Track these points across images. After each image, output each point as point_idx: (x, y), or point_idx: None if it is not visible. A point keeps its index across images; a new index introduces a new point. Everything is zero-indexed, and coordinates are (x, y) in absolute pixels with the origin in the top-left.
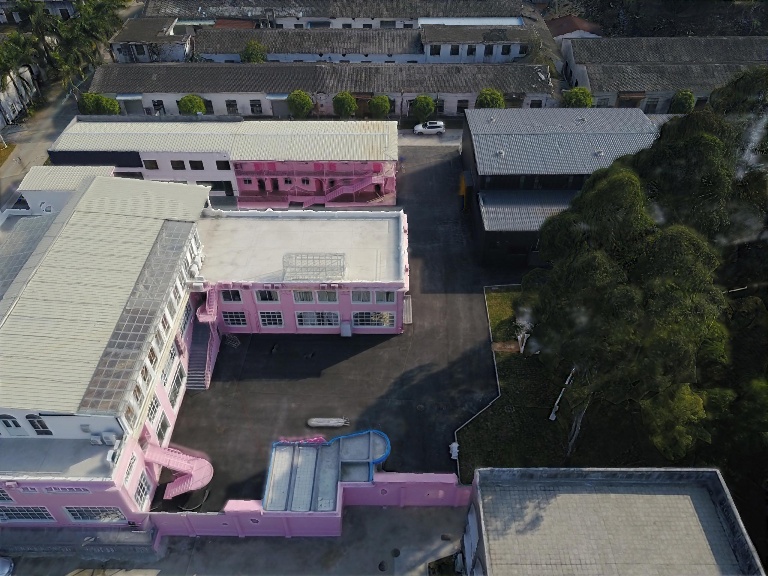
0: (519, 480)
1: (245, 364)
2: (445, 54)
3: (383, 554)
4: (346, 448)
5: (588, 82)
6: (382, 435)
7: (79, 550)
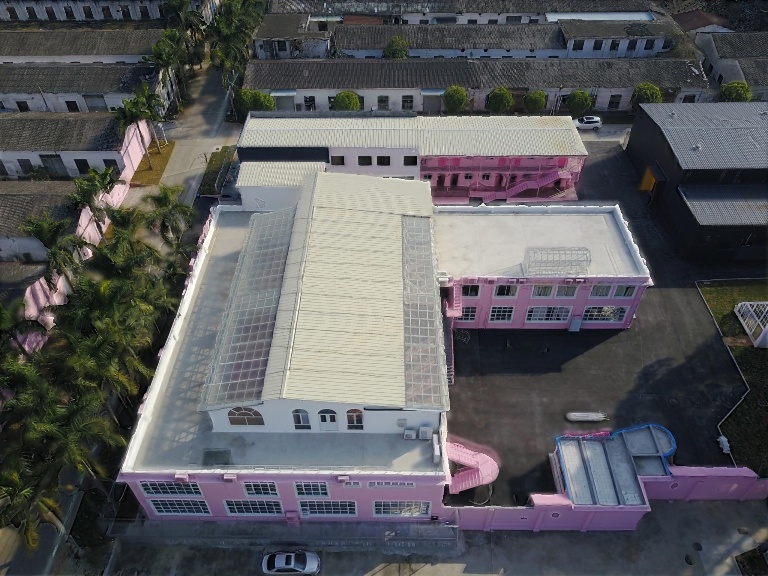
0: None
1: (482, 359)
2: (587, 49)
3: (685, 548)
4: (630, 442)
5: (741, 76)
6: (663, 429)
7: (380, 545)
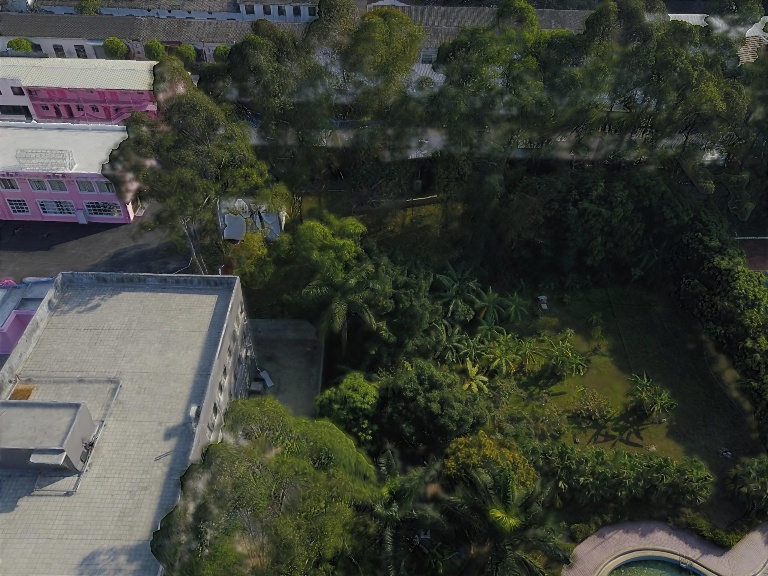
0: (98, 284)
1: None
2: (259, 13)
3: None
4: (32, 290)
5: None
6: None
7: None
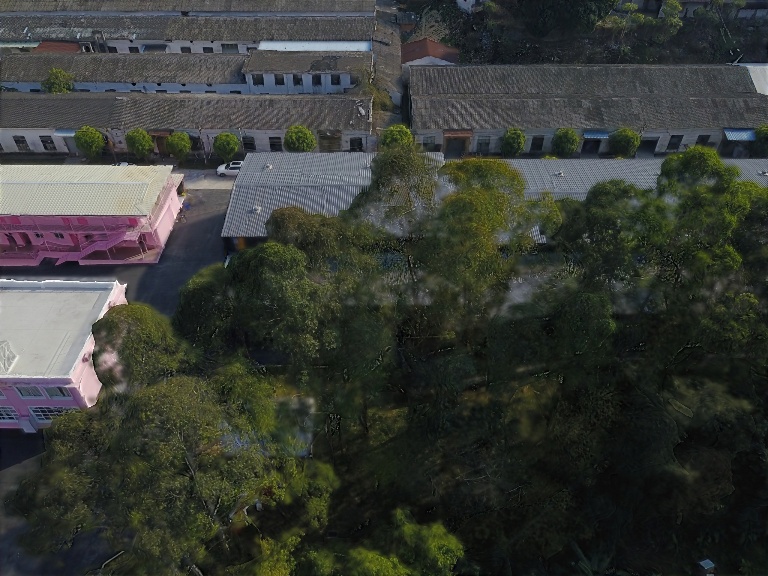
0: None
1: None
2: (270, 84)
3: None
4: None
5: None
6: None
7: None
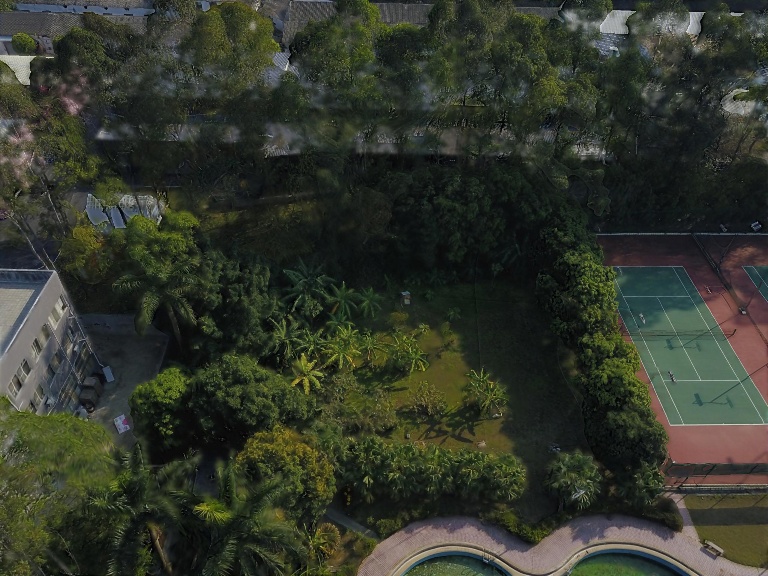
0: None
1: None
2: None
3: None
4: None
5: None
6: None
7: None
